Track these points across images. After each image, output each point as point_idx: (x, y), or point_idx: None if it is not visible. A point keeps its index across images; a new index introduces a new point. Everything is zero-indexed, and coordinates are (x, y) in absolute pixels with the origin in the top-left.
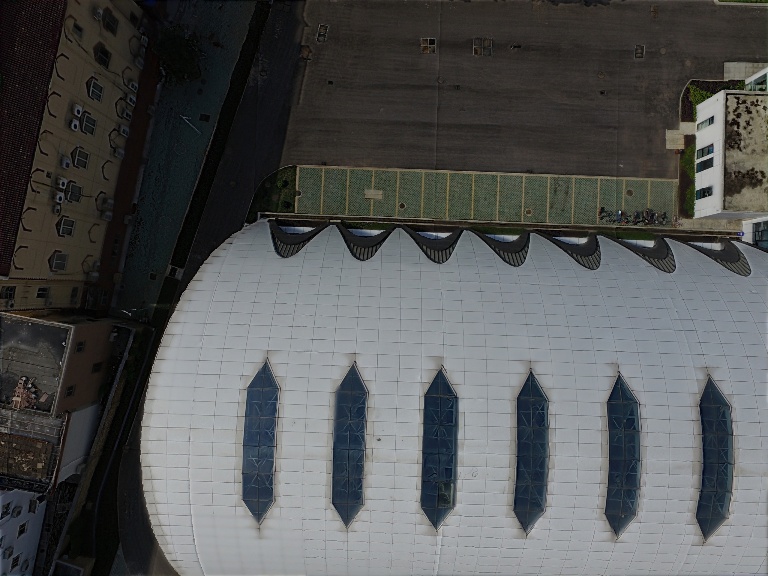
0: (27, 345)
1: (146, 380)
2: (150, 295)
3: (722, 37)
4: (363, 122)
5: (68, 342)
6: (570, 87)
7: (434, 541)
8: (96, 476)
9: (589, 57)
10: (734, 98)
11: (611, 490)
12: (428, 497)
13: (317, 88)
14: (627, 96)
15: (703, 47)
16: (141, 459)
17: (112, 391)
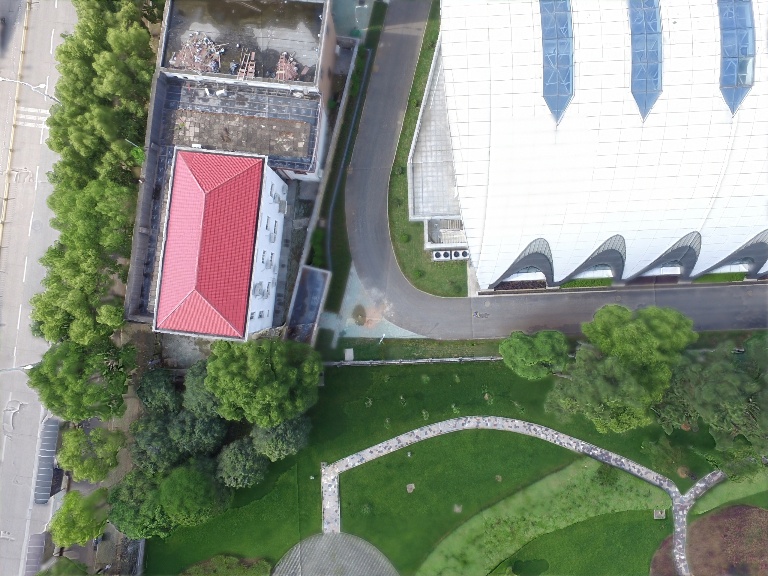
0: (284, 22)
1: (364, 103)
2: (360, 21)
3: None
4: None
5: (325, 14)
6: None
7: (728, 131)
8: (327, 192)
9: None
10: None
11: None
12: (724, 81)
13: None
14: None
15: None
16: (443, 63)
17: (342, 100)
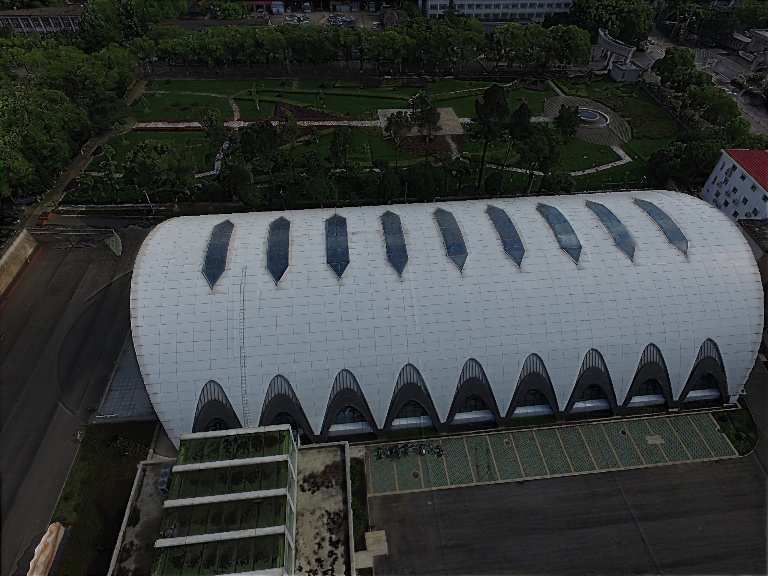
0: None
1: None
2: None
3: None
4: (710, 511)
5: None
6: None
7: None
8: None
9: None
10: None
11: None
12: None
13: None
14: None
15: None
16: None
17: None
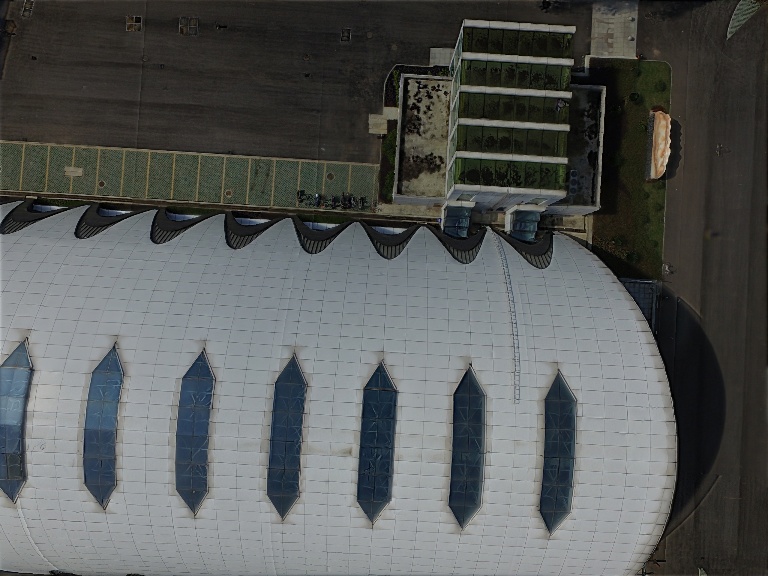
0: None
1: None
2: None
3: (429, 22)
4: (65, 99)
5: None
6: (275, 69)
7: (16, 513)
8: None
9: (295, 39)
10: (415, 82)
11: (181, 465)
12: (3, 469)
13: (20, 63)
14: (331, 79)
15: (410, 32)
16: None
17: None
